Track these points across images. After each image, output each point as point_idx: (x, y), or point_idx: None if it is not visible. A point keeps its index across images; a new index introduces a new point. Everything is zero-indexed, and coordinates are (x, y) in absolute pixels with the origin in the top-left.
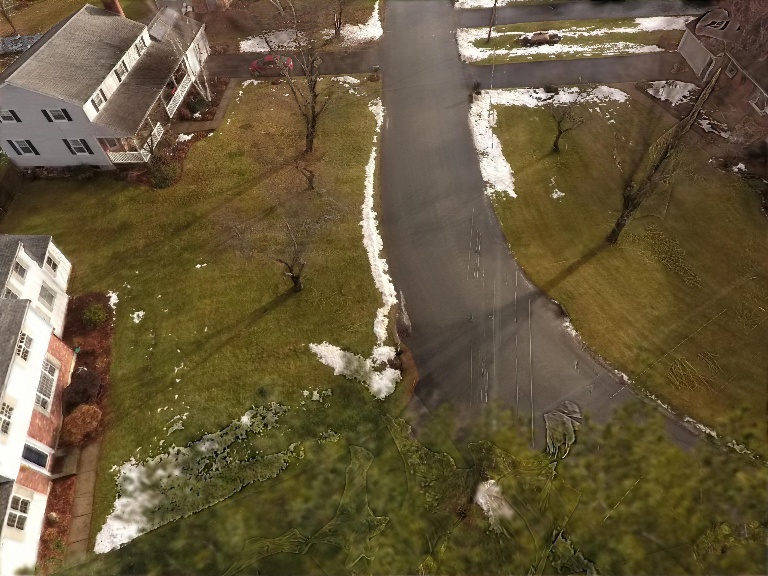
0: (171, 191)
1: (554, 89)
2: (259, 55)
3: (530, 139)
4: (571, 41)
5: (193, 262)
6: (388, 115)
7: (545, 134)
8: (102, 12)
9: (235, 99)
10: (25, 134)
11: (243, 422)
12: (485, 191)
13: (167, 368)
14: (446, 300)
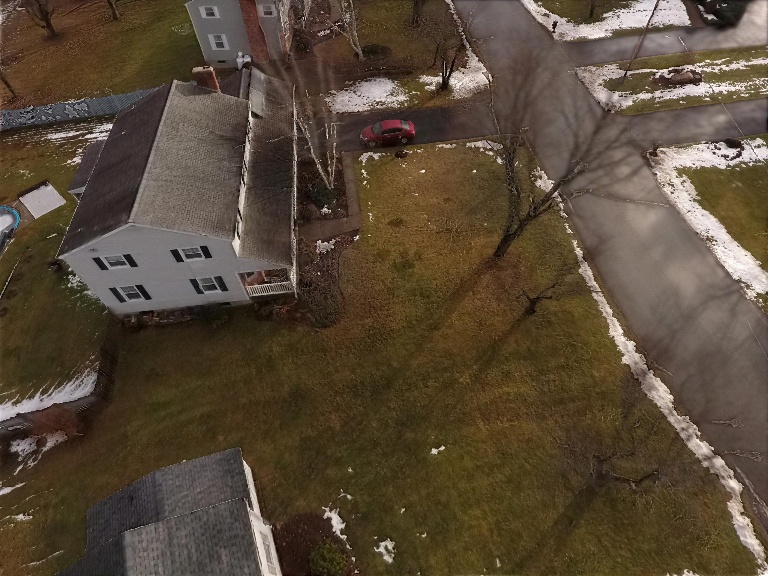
0: (342, 331)
1: (739, 143)
2: (359, 116)
3: (751, 214)
4: (715, 78)
5: (425, 445)
6: (564, 192)
7: (763, 205)
8: (195, 90)
9: (362, 182)
10: (137, 279)
11: None
12: (746, 295)
13: None
14: None
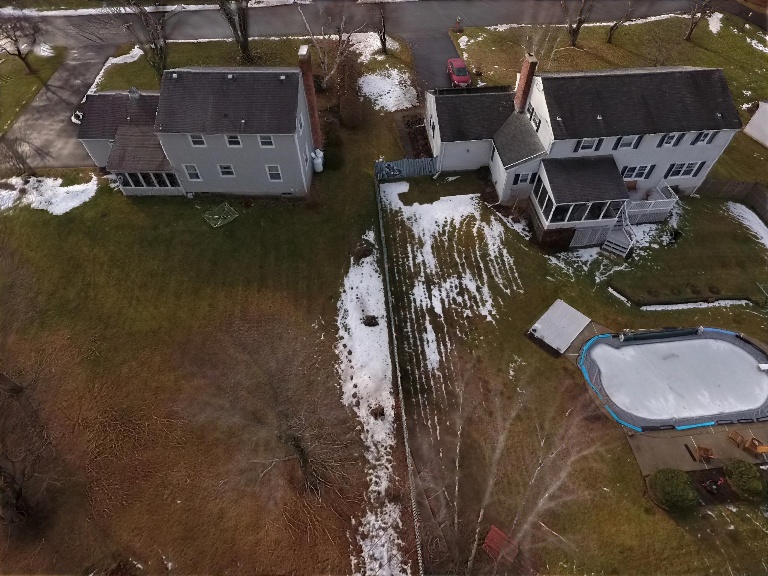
0: None
1: None
2: None
3: None
4: None
5: None
6: (509, 23)
7: None
8: None
9: None
10: None
11: (762, 49)
12: None
13: (763, 74)
14: (660, 3)
